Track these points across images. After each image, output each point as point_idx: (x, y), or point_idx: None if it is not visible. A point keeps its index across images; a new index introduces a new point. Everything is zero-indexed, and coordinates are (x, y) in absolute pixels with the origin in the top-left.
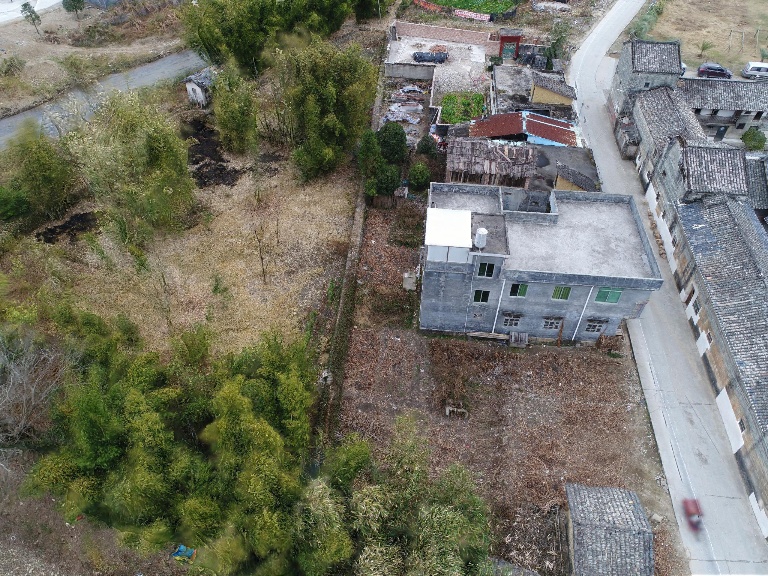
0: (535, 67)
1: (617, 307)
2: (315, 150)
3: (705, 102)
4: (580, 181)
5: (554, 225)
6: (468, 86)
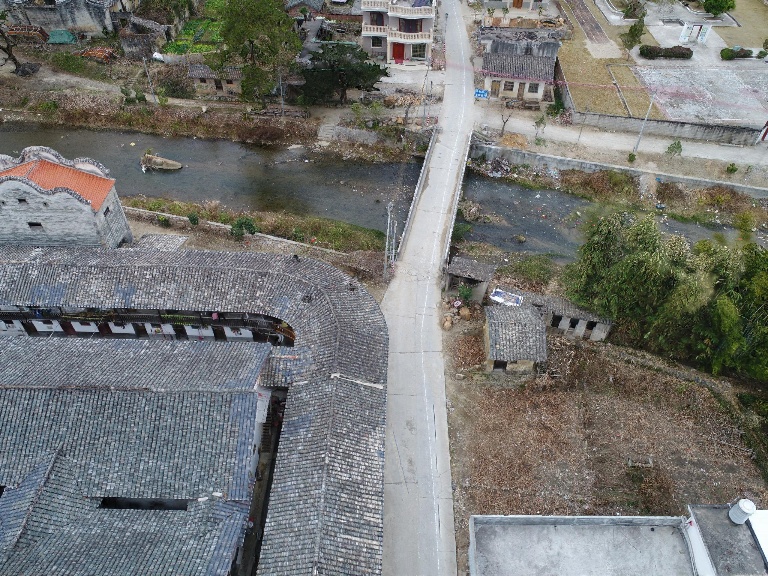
0: None
1: None
2: None
3: None
4: None
5: None
6: None
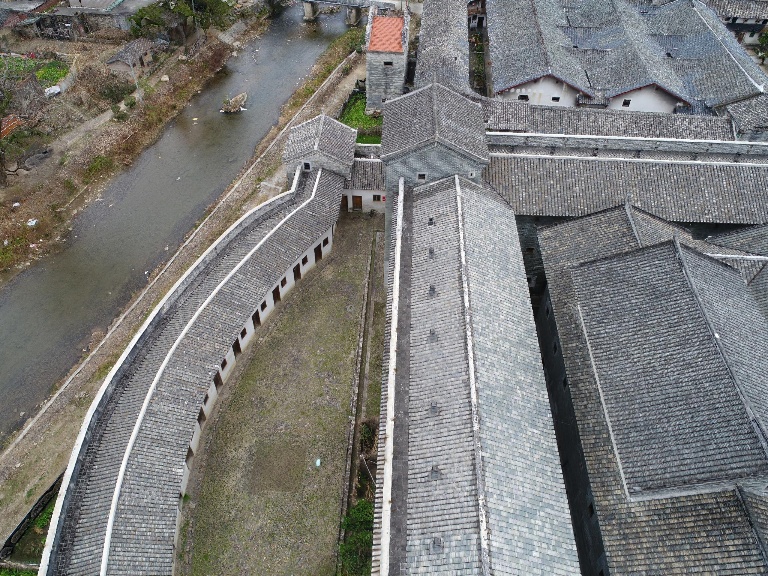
0: None
1: None
2: None
3: None
4: None
5: None
6: None
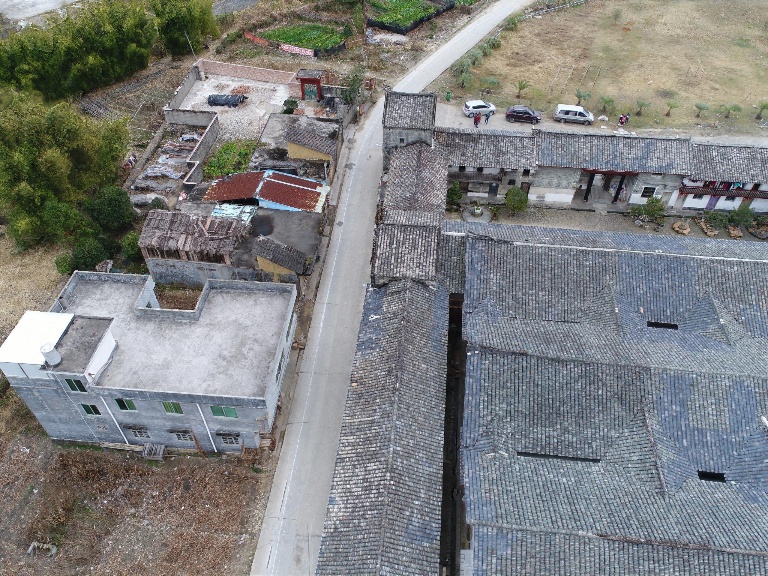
0: (334, 111)
1: (240, 422)
2: (11, 221)
3: (465, 159)
4: (282, 257)
5: (194, 323)
6: (253, 133)
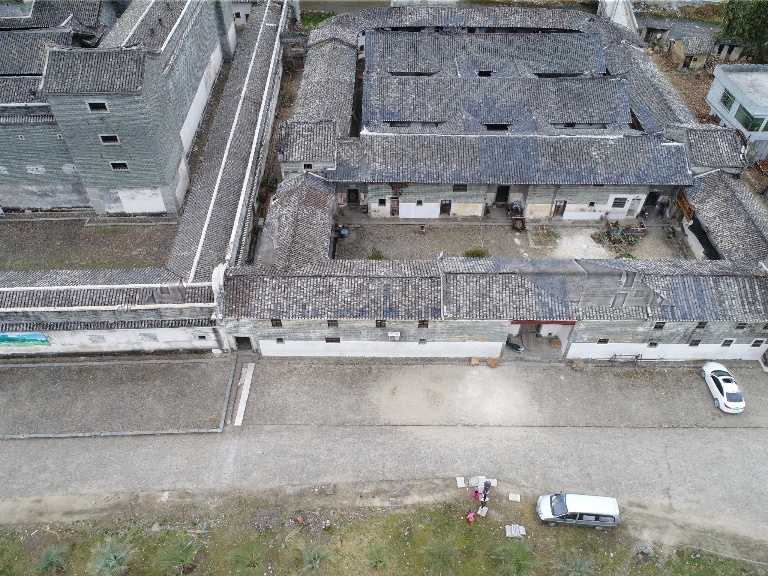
0: None
1: None
2: None
3: None
4: None
5: None
6: None
